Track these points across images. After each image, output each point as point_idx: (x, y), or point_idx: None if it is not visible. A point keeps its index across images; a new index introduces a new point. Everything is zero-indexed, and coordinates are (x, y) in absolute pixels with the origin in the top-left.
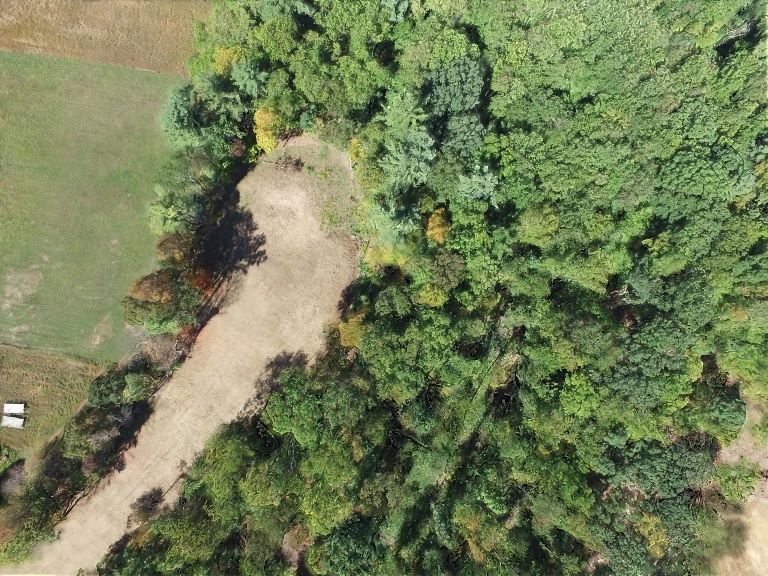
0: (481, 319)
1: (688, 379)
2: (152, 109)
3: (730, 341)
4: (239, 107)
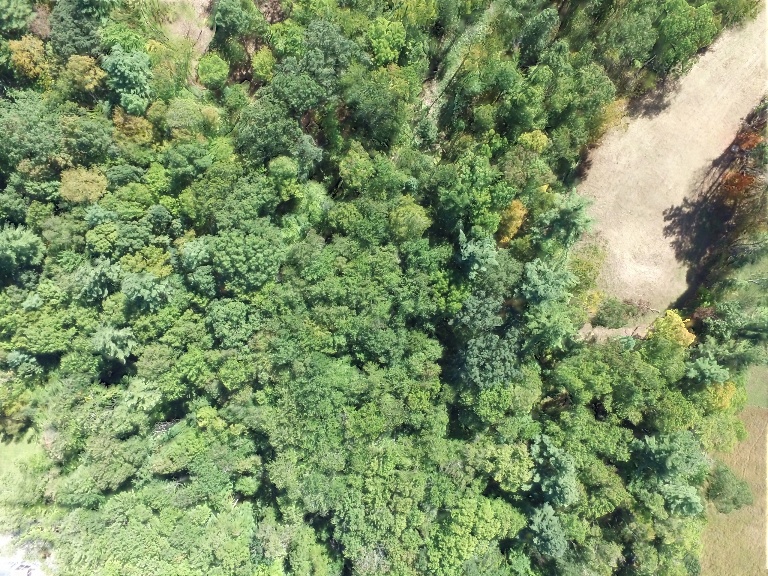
0: (469, 130)
1: (279, 45)
2: (767, 369)
3: (205, 100)
4: (710, 348)
